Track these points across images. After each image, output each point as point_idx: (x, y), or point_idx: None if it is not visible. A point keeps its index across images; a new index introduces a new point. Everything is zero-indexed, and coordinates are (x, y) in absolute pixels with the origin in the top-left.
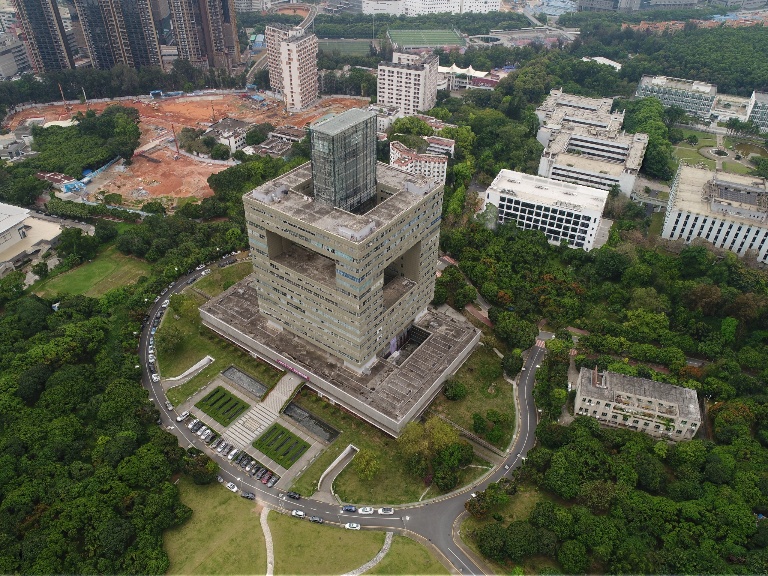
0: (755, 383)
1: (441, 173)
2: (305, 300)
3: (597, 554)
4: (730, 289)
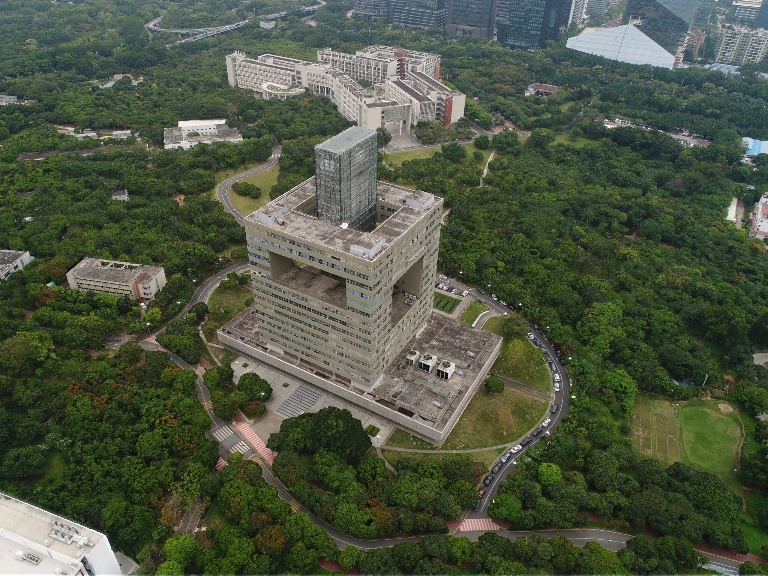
0: None
1: None
2: None
3: None
4: None
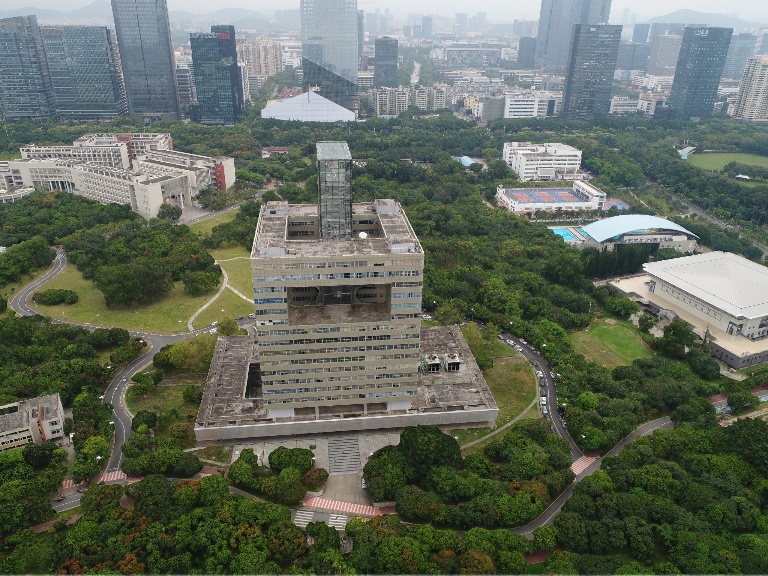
0: None
1: None
2: None
3: None
4: None
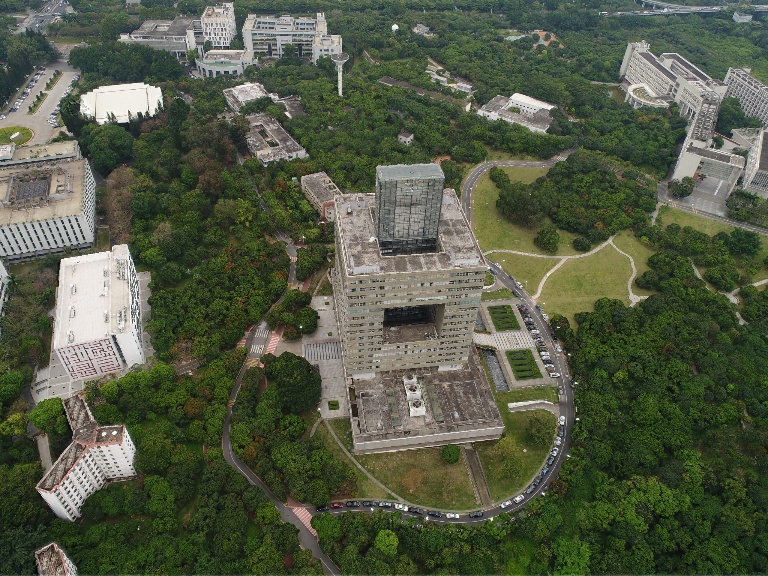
0: None
1: None
2: None
3: None
4: (175, 185)
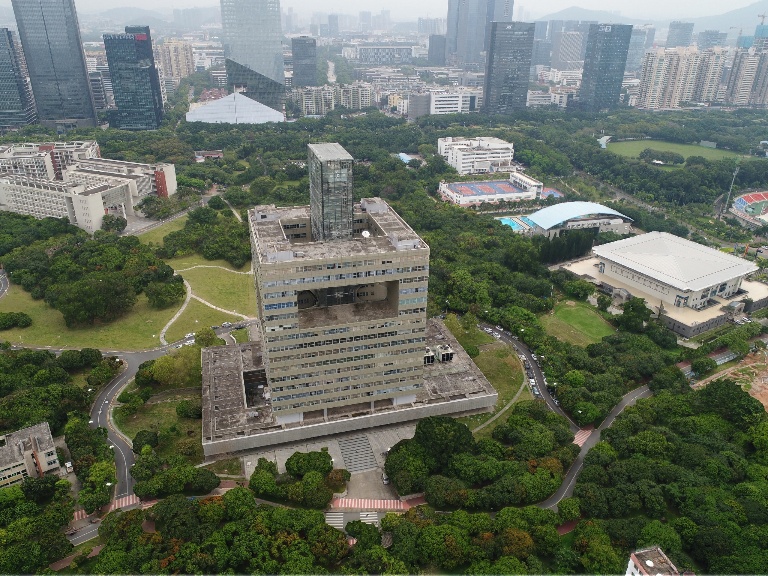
0: None
1: None
2: None
3: None
4: None
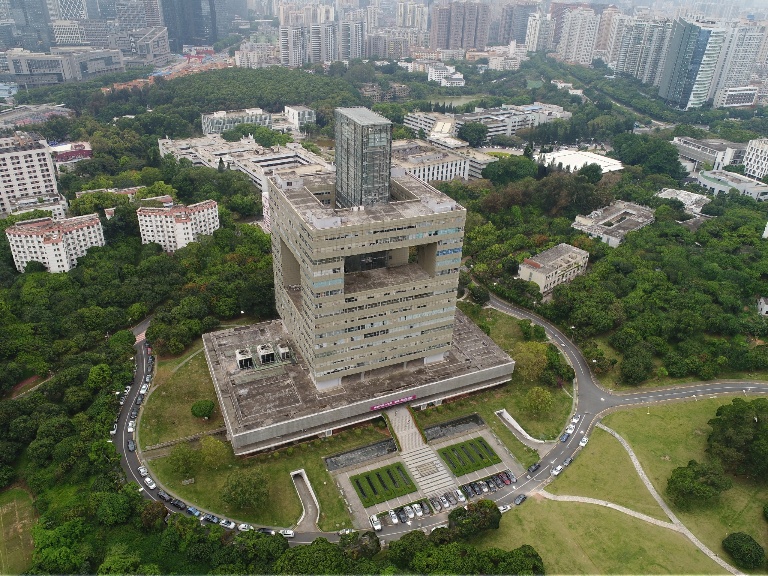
0: (566, 227)
1: (215, 218)
2: (391, 315)
3: (668, 329)
4: None
